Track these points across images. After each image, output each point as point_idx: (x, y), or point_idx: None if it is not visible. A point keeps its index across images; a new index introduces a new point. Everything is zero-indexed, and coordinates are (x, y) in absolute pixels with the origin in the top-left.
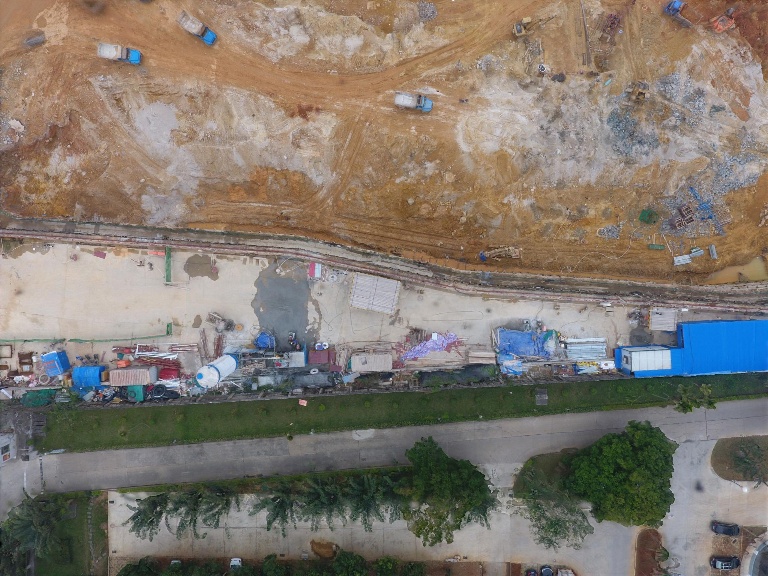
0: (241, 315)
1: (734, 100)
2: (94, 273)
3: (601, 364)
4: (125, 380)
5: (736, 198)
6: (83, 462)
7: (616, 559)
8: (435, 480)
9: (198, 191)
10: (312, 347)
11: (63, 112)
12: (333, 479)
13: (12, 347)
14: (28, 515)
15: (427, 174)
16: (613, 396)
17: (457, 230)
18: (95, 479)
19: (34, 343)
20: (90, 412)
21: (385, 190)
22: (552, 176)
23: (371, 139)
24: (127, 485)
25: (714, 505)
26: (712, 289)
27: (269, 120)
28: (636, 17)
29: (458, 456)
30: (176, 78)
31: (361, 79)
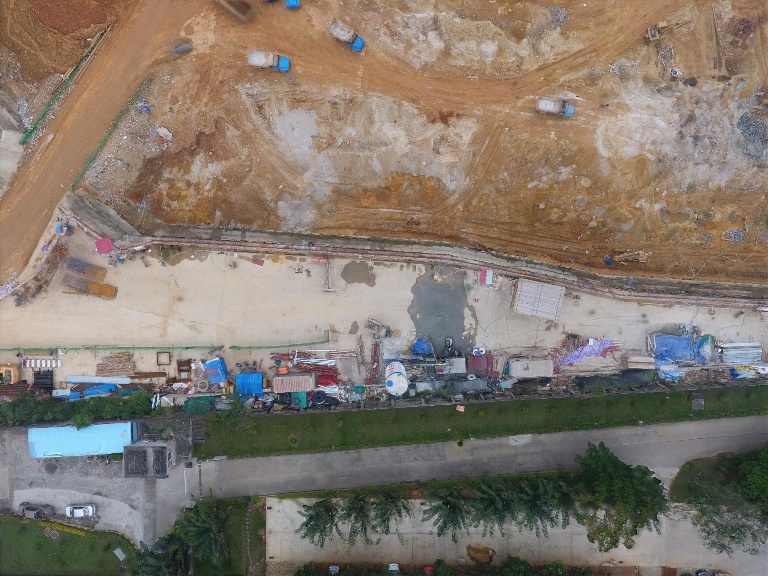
0: (398, 321)
1: None
2: (252, 280)
3: (758, 369)
4: (288, 387)
5: None
6: (241, 468)
7: None
8: (618, 486)
9: (331, 197)
10: (468, 353)
11: (211, 119)
12: None
13: (170, 354)
14: (204, 522)
15: (560, 179)
16: None
17: (583, 234)
18: (253, 485)
19: (192, 350)
20: (249, 419)
21: (518, 195)
22: (683, 180)
23: (509, 144)
24: (285, 491)
25: None
26: None
27: (410, 126)
28: (767, 21)
29: None
30: (322, 85)
31: (501, 85)
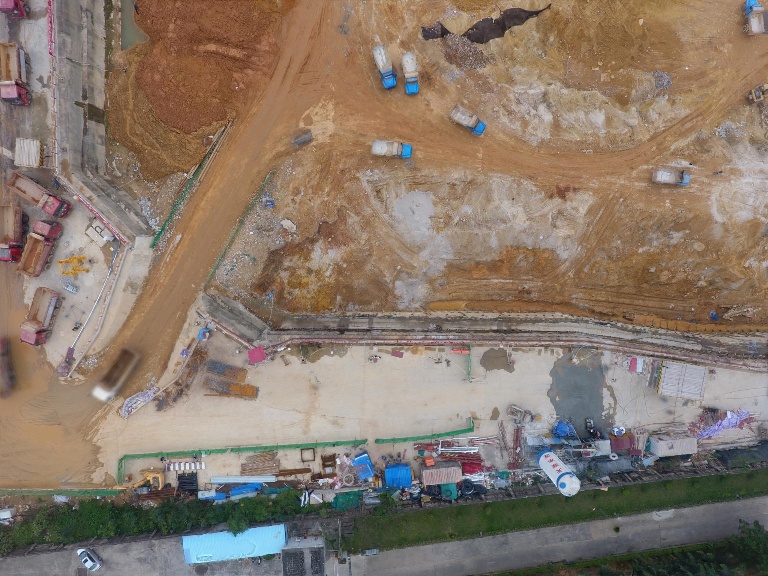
0: (538, 405)
1: None
2: (392, 373)
3: None
4: (438, 479)
5: None
6: (391, 559)
7: None
8: None
9: (444, 272)
10: (608, 432)
11: (334, 209)
12: (638, 561)
13: (314, 450)
14: None
15: (671, 243)
16: None
17: (690, 293)
18: (403, 575)
19: None
20: None
21: (630, 261)
22: None
23: (624, 214)
24: None
25: None
26: None
27: (528, 203)
28: None
29: None
30: (443, 169)
31: (615, 156)
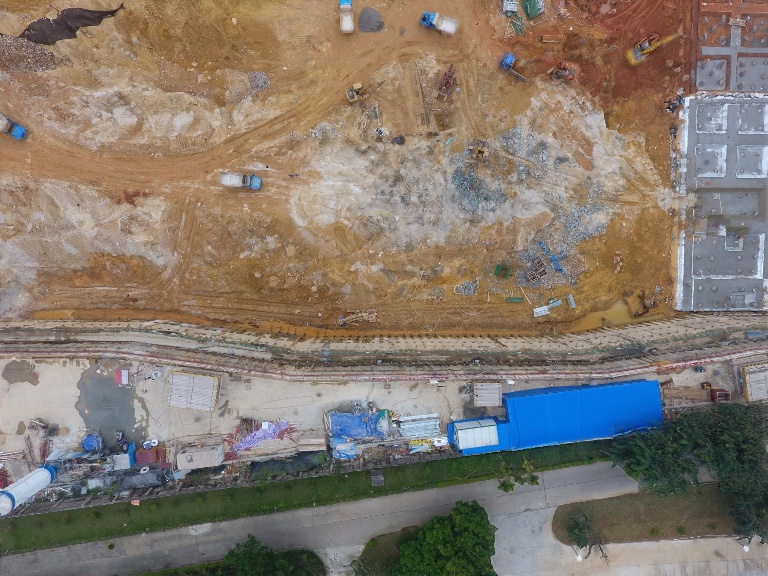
0: (66, 418)
1: (577, 151)
2: None
3: (434, 441)
4: None
5: (588, 247)
6: None
7: None
8: None
9: (38, 280)
10: (142, 445)
11: None
12: None
13: None
14: None
15: (270, 248)
16: (450, 471)
17: (312, 298)
18: None
19: None
20: None
21: (229, 267)
22: (399, 240)
23: (205, 219)
24: None
25: (559, 571)
26: (554, 349)
27: (95, 208)
28: (472, 73)
29: (298, 543)
30: None
31: (188, 160)
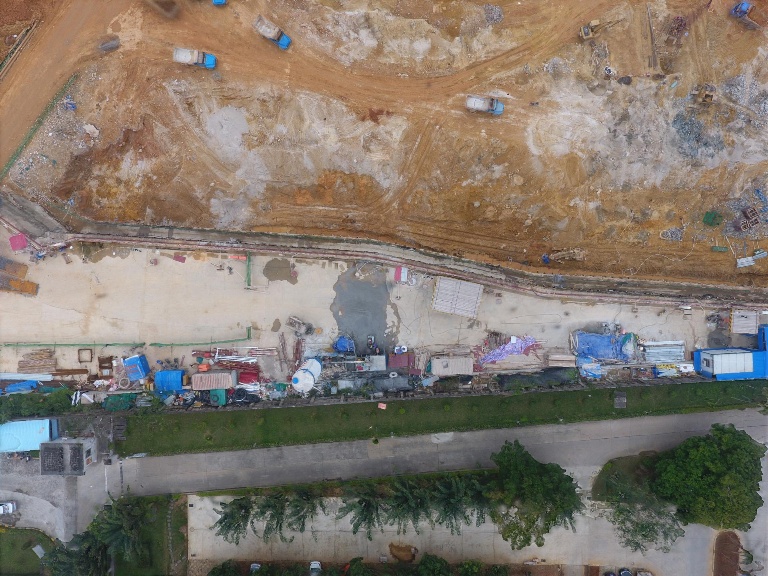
0: (320, 319)
1: None
2: (174, 277)
3: (680, 367)
4: (207, 384)
5: None
6: (163, 466)
7: (694, 562)
8: (527, 484)
9: (265, 195)
10: (391, 350)
11: (138, 116)
12: (413, 482)
13: (92, 351)
14: (117, 519)
15: (494, 177)
16: (692, 399)
17: (521, 233)
18: (175, 483)
19: (114, 347)
20: (170, 416)
21: (452, 193)
22: (618, 179)
23: (441, 142)
24: (207, 489)
25: None
26: None
27: (340, 124)
28: (702, 19)
29: (537, 459)
30: (250, 82)
31: (431, 82)
